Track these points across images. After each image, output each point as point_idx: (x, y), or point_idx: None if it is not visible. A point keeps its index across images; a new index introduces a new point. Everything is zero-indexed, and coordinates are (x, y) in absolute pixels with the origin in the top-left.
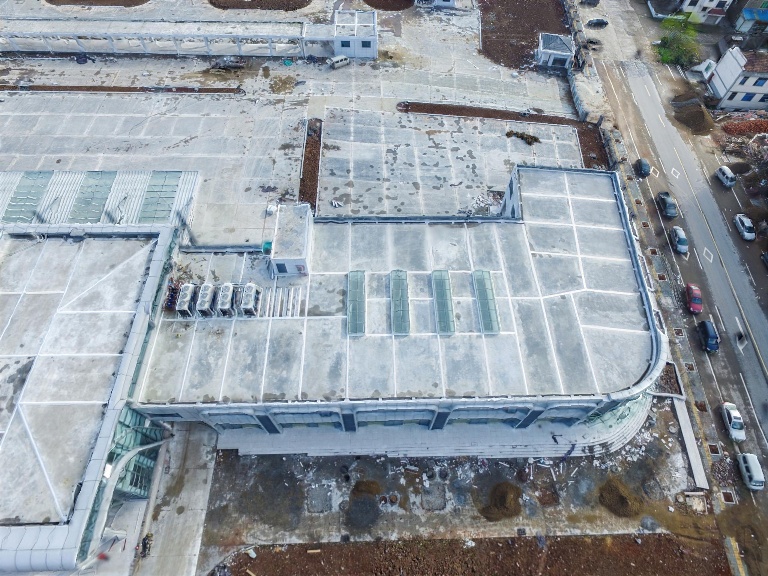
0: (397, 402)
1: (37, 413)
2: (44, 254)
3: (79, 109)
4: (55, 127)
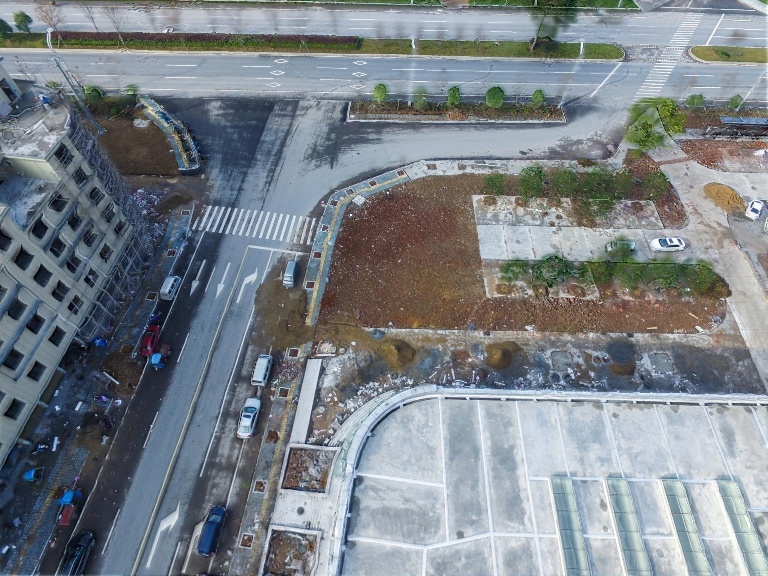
0: (655, 394)
1: None
2: None
3: None
4: None
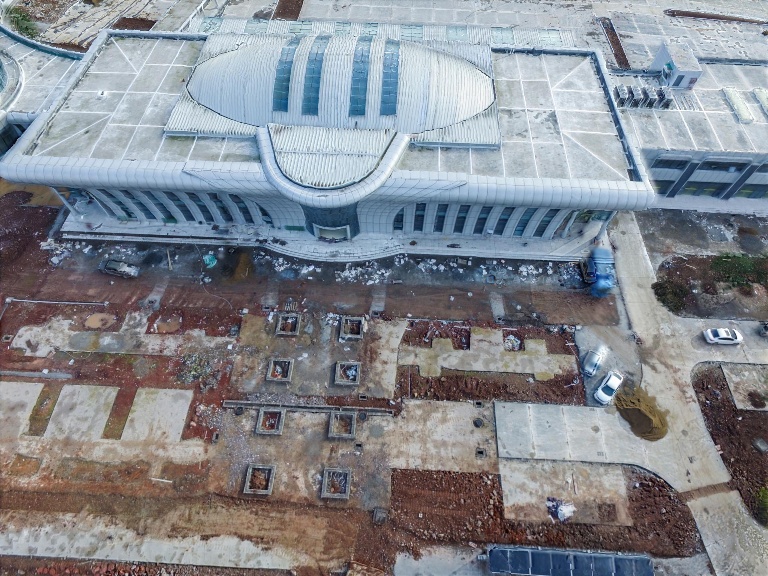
0: None
1: (576, 136)
2: (519, 60)
3: (418, 5)
4: (408, 15)
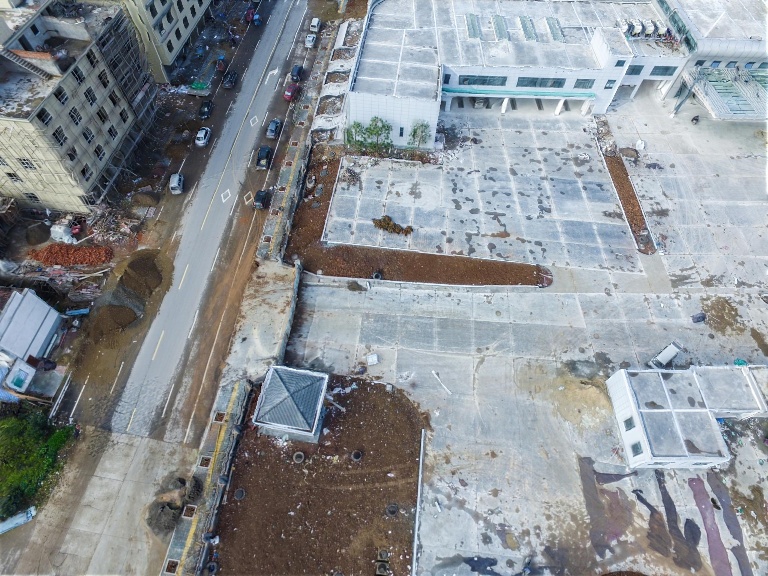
0: None
1: None
2: (765, 34)
3: None
4: None
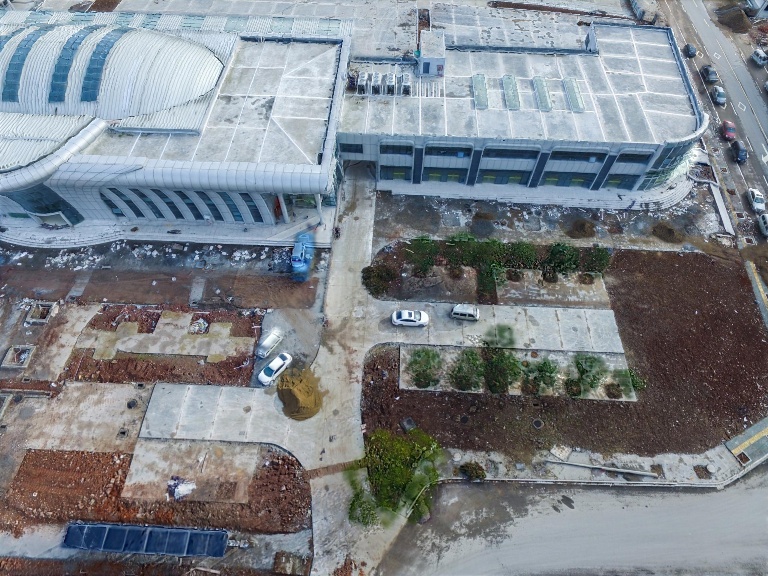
0: (515, 138)
1: (284, 121)
2: (266, 48)
3: None
4: (226, 8)
